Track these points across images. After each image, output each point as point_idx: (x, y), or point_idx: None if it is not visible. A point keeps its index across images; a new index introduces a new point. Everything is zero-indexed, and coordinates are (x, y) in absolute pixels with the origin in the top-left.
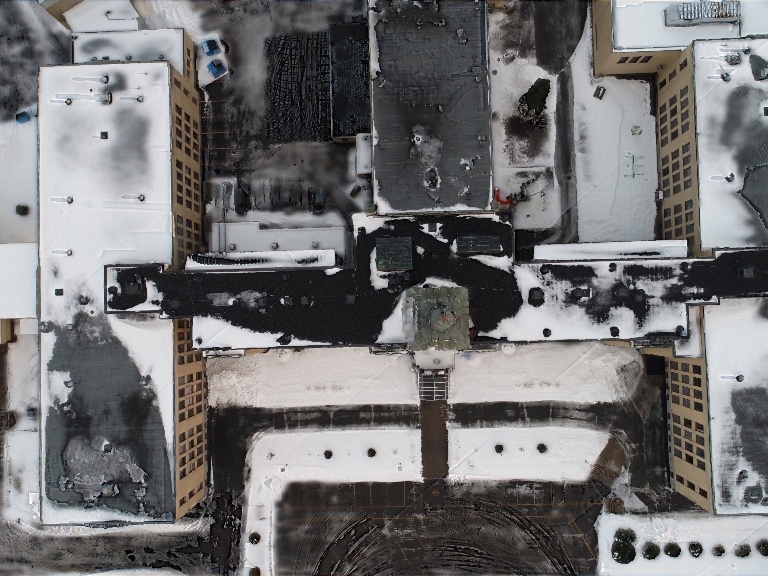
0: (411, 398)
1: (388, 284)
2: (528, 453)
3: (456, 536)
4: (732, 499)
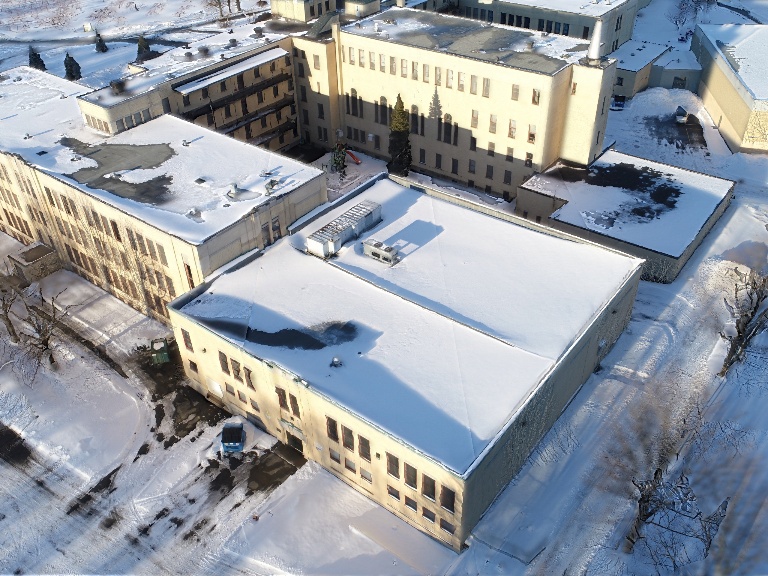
0: None
1: None
2: None
3: None
4: (18, 72)
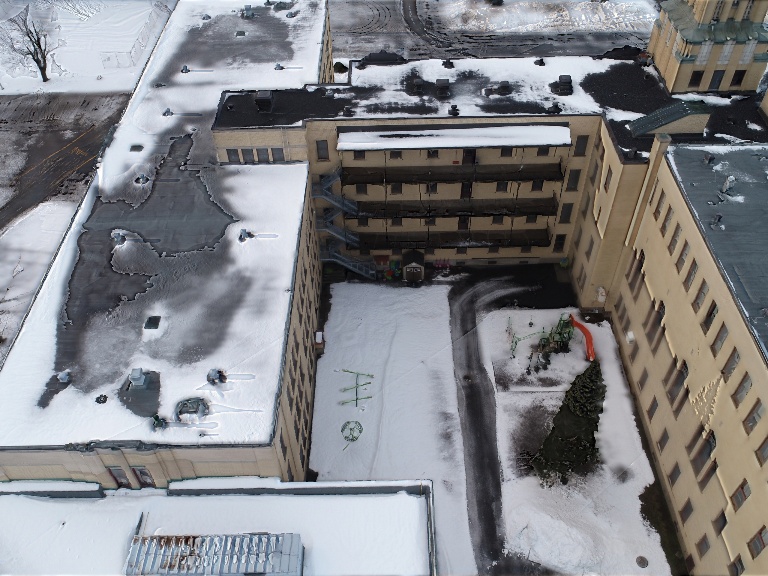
0: None
1: None
2: None
3: None
4: (308, 3)
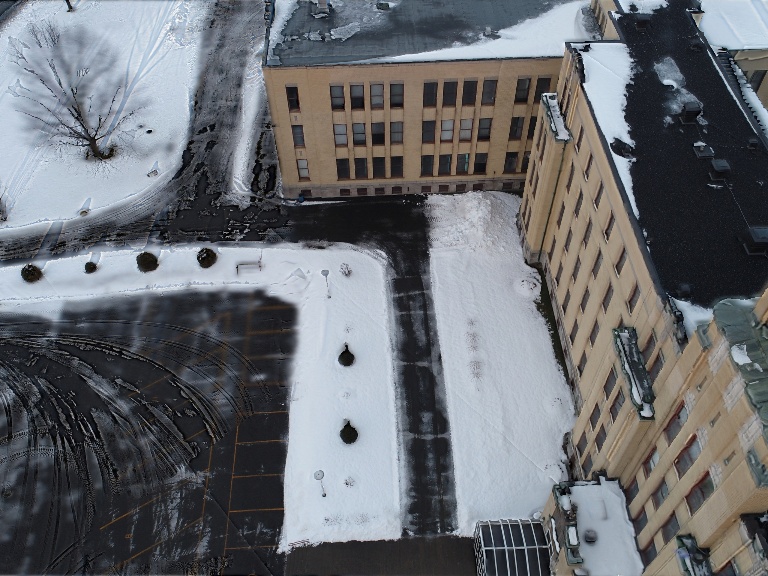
0: (473, 512)
1: None
2: None
3: None
4: None
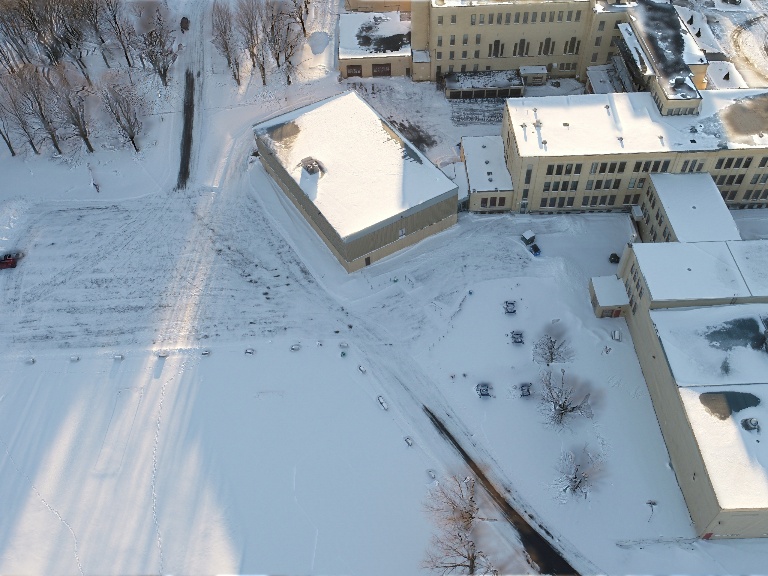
0: None
1: (633, 2)
2: (696, 27)
3: (760, 54)
4: None
